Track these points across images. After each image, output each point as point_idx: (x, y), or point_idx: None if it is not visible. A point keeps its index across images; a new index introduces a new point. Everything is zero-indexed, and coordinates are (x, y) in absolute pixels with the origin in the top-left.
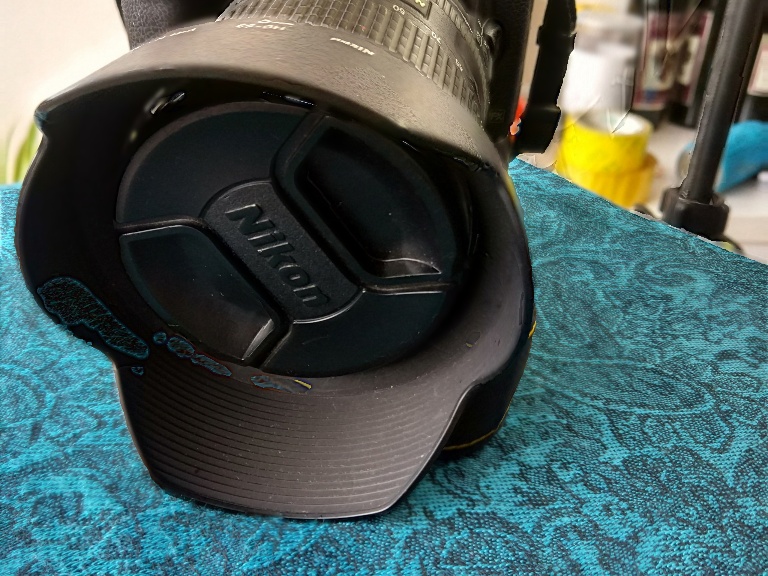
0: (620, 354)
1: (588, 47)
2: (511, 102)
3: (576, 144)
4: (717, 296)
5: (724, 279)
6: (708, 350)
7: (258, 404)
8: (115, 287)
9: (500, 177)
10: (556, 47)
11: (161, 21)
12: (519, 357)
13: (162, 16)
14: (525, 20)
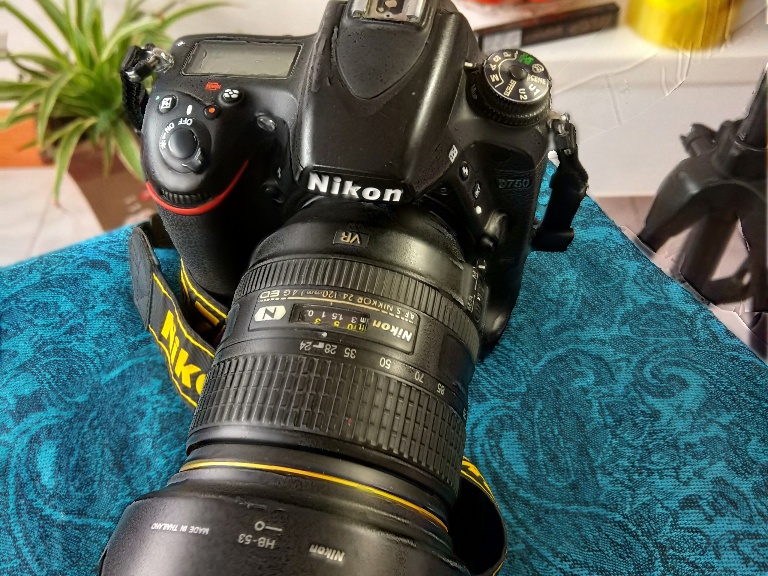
0: (596, 499)
1: (646, 8)
2: (520, 252)
3: (629, 95)
4: (702, 413)
5: (715, 385)
6: (675, 494)
7: None
8: None
9: None
10: (568, 196)
11: (191, 225)
12: None
13: (191, 222)
14: (530, 207)
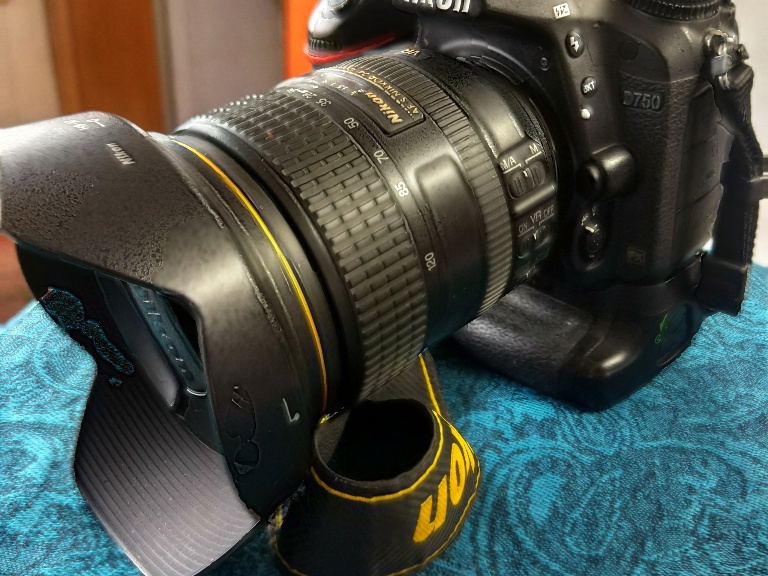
0: None
1: None
2: (652, 244)
3: None
4: None
5: None
6: None
7: (192, 451)
8: (96, 309)
9: (198, 307)
10: (736, 191)
11: None
12: (371, 515)
13: None
14: (663, 152)
